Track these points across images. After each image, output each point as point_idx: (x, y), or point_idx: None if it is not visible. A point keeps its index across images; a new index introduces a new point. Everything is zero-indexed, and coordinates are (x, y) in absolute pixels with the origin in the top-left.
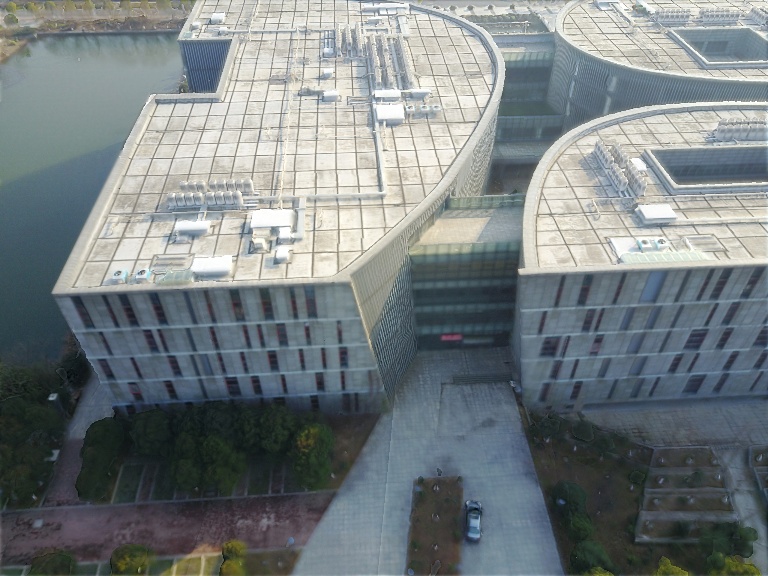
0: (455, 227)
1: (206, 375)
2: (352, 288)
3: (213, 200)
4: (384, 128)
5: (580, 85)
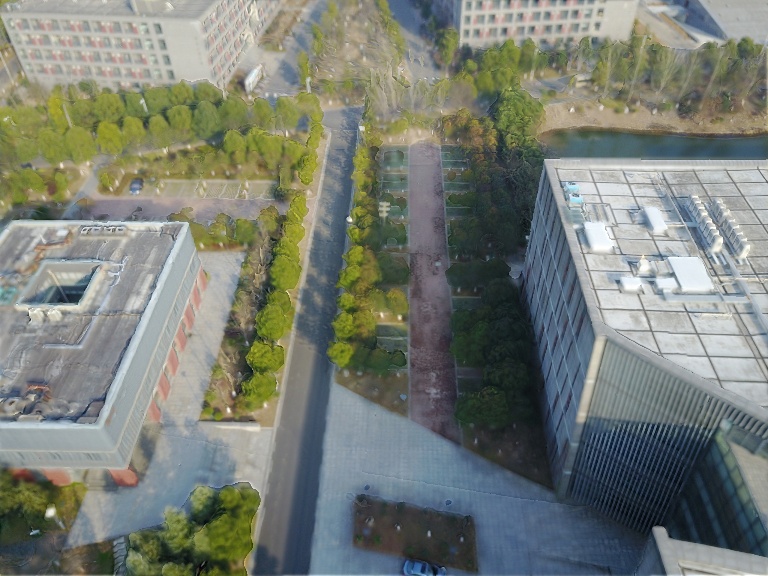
0: None
1: (541, 305)
2: (594, 344)
3: (704, 226)
4: None
5: None
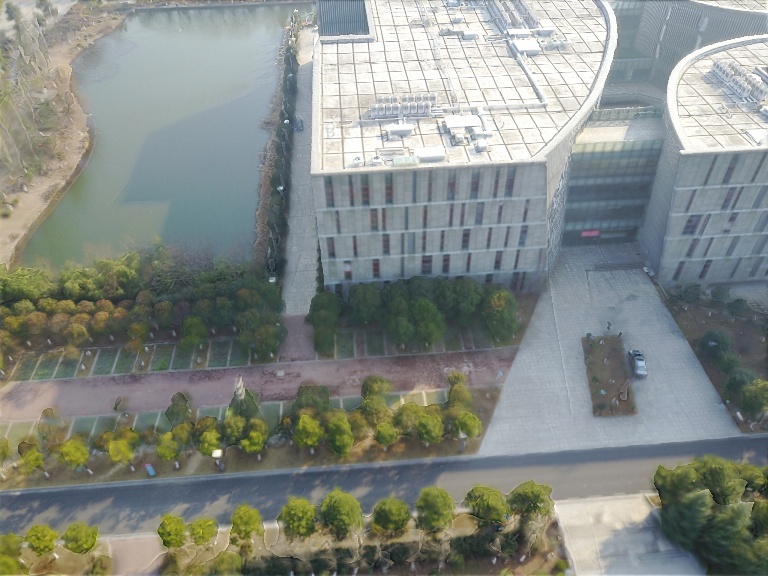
0: (601, 133)
1: (408, 253)
2: (546, 167)
3: (408, 109)
4: (526, 57)
5: (672, 28)
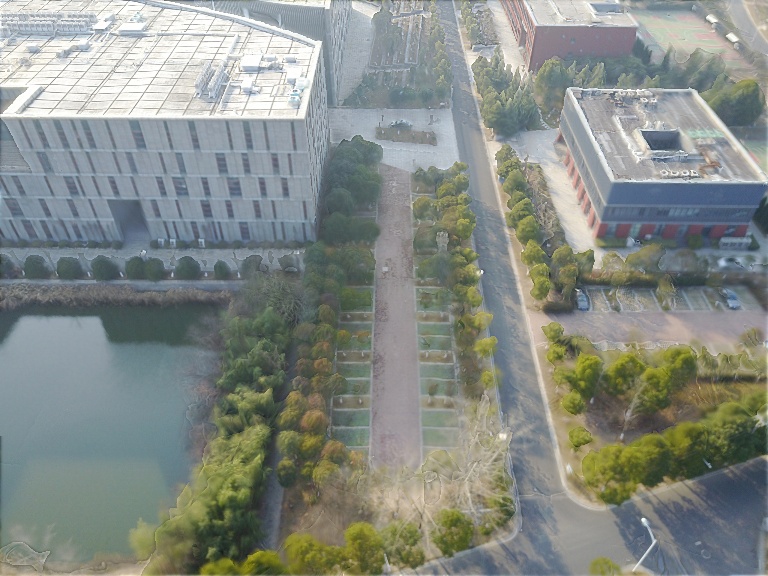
0: None
1: None
2: None
3: None
4: None
5: None
